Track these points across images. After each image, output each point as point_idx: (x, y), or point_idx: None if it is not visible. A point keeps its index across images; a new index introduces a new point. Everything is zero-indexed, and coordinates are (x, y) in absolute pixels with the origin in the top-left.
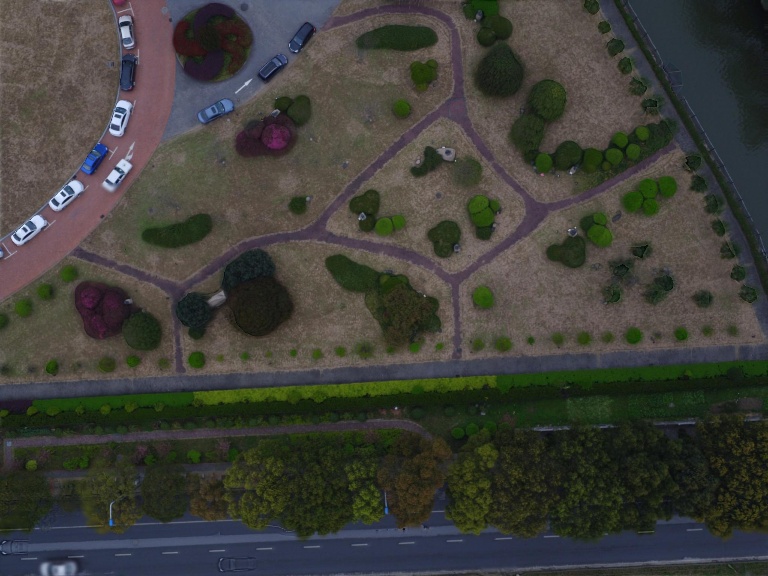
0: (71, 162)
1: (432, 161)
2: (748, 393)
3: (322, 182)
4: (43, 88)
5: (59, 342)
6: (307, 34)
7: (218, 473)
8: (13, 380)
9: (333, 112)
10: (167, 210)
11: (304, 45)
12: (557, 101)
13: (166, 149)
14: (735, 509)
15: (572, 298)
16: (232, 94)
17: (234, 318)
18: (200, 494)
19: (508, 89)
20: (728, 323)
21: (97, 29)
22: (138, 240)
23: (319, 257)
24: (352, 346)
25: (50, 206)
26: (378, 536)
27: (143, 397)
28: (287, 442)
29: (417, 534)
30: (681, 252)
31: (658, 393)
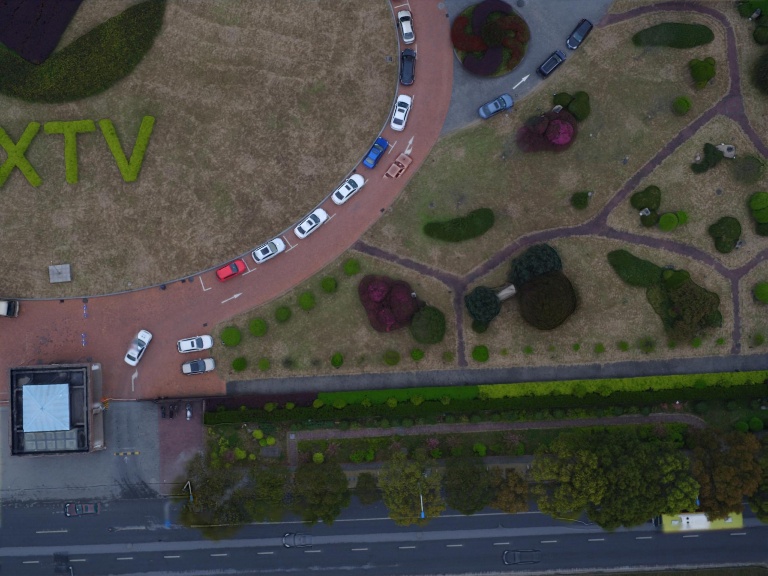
0: (351, 156)
1: (714, 157)
2: None
3: (602, 178)
4: (322, 82)
5: (342, 335)
6: (587, 31)
7: (502, 466)
8: (295, 373)
9: (611, 108)
10: (448, 204)
11: (581, 42)
12: None
13: (445, 144)
14: None
15: None
16: (510, 90)
17: (517, 312)
18: (484, 487)
19: None
20: None
21: (375, 24)
22: (419, 234)
23: (600, 252)
24: (633, 340)
25: (333, 199)
26: (662, 529)
27: (428, 390)
28: (584, 435)
29: (701, 527)
30: None
31: None
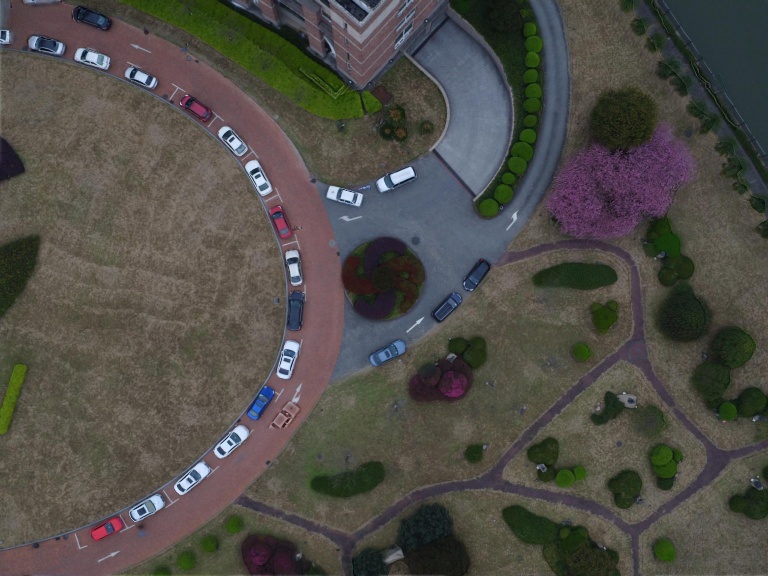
0: (235, 405)
1: (614, 410)
2: None
3: (499, 429)
4: (205, 326)
5: None
6: (484, 274)
7: None
8: None
9: (509, 354)
10: (337, 457)
11: (479, 283)
12: (748, 355)
13: (335, 391)
14: None
15: (754, 549)
16: (403, 333)
17: (408, 571)
18: None
19: (694, 337)
20: None
21: (261, 263)
22: (307, 488)
23: (496, 507)
24: None
25: (215, 454)
26: None
27: None
28: None
29: None
30: None
31: None
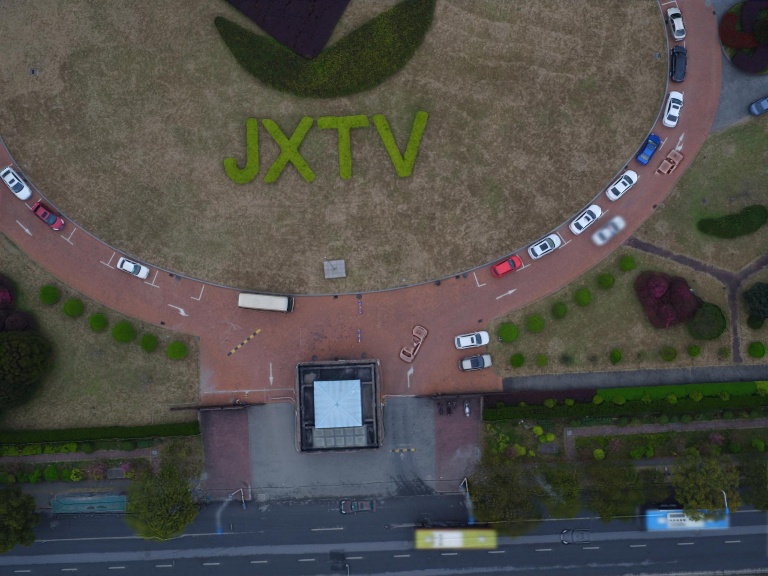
0: (623, 152)
1: None
2: None
3: None
4: (592, 78)
5: (617, 331)
6: None
7: None
8: (572, 369)
9: None
10: (720, 201)
11: None
12: None
13: (716, 140)
14: None
15: None
16: None
17: None
18: (762, 483)
19: None
20: None
21: (643, 20)
22: (692, 230)
23: None
24: None
25: (608, 195)
26: None
27: (706, 386)
28: None
29: None
30: None
31: None
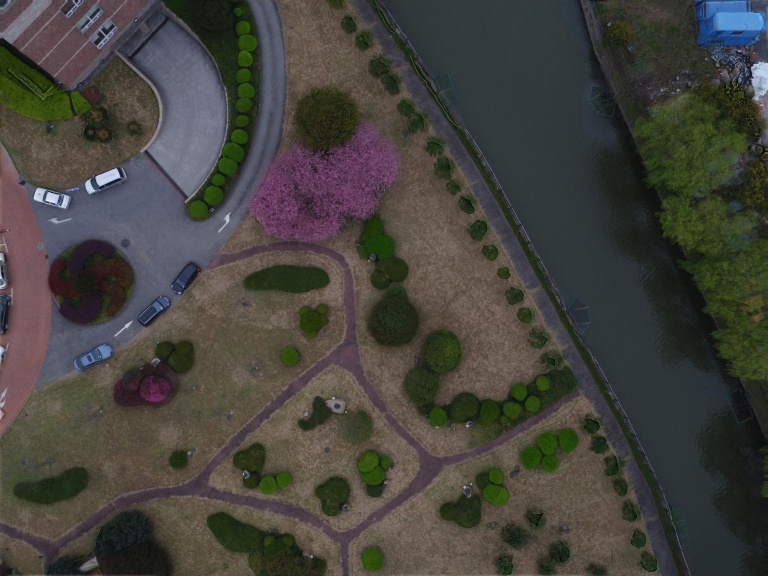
0: None
1: (320, 416)
2: None
3: (205, 434)
4: None
5: None
6: (190, 276)
7: None
8: None
9: (218, 358)
10: (41, 462)
11: (188, 286)
12: (450, 359)
13: (40, 396)
14: None
15: (467, 558)
16: (111, 337)
17: None
18: None
19: (400, 341)
20: None
21: None
22: (10, 494)
23: (201, 514)
24: None
25: None
26: None
27: None
28: None
29: None
30: (582, 508)
31: None
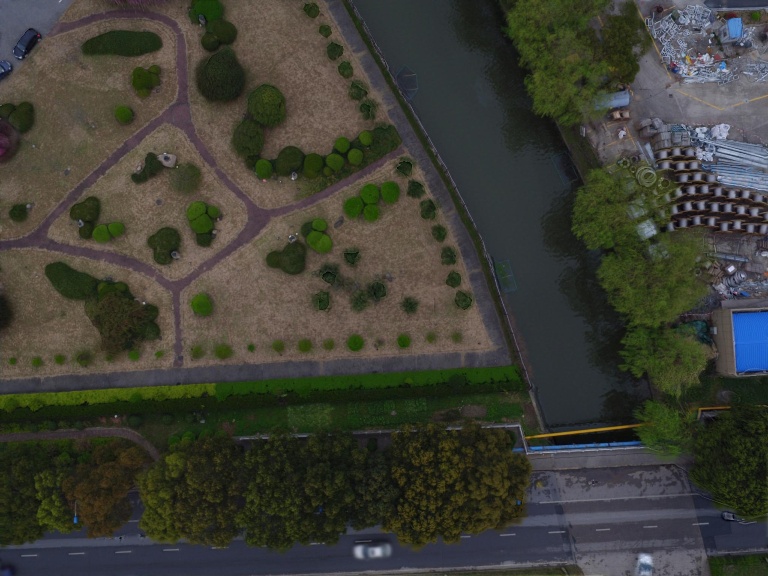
0: None
1: (150, 167)
2: (472, 401)
3: (44, 189)
4: None
5: None
6: (29, 40)
7: None
8: None
9: (57, 119)
10: None
11: (29, 51)
12: (269, 106)
13: None
14: (412, 520)
15: (293, 305)
16: None
17: None
18: None
19: (225, 94)
20: (454, 330)
21: None
22: None
23: (40, 264)
24: (72, 354)
25: None
26: (95, 545)
27: None
28: None
29: (134, 543)
30: (405, 258)
31: (378, 401)
